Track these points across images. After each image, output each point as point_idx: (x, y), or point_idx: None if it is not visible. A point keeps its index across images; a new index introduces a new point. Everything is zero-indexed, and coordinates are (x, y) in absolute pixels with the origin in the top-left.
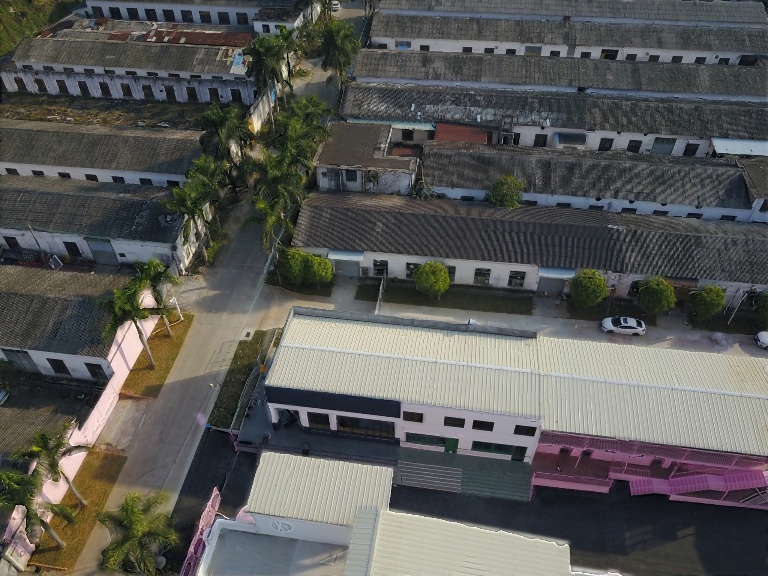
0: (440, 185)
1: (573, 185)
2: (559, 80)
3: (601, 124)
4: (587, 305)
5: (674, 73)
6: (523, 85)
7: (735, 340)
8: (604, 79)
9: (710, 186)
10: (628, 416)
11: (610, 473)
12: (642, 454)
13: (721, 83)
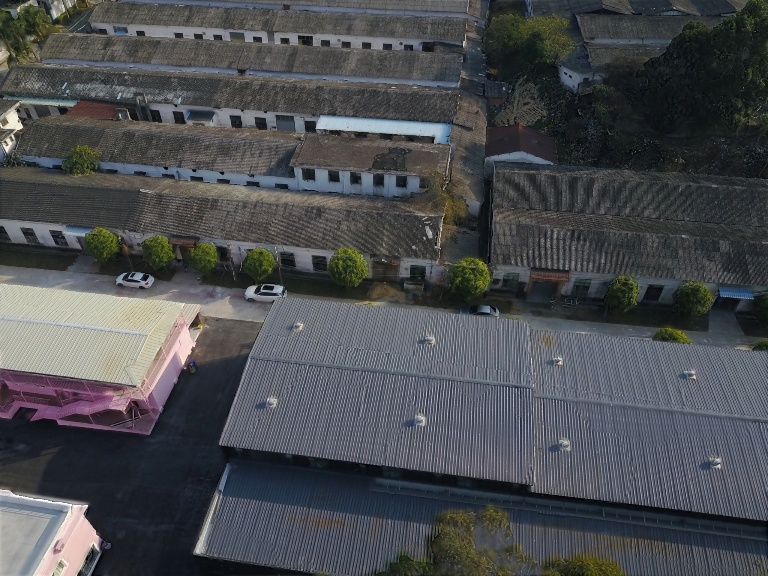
0: (29, 154)
1: (146, 155)
2: (221, 62)
3: (226, 102)
4: (99, 260)
5: (327, 57)
6: (188, 67)
7: (230, 293)
8: (262, 62)
9: (266, 157)
10: (0, 347)
11: (15, 401)
12: (23, 382)
13: (365, 66)
